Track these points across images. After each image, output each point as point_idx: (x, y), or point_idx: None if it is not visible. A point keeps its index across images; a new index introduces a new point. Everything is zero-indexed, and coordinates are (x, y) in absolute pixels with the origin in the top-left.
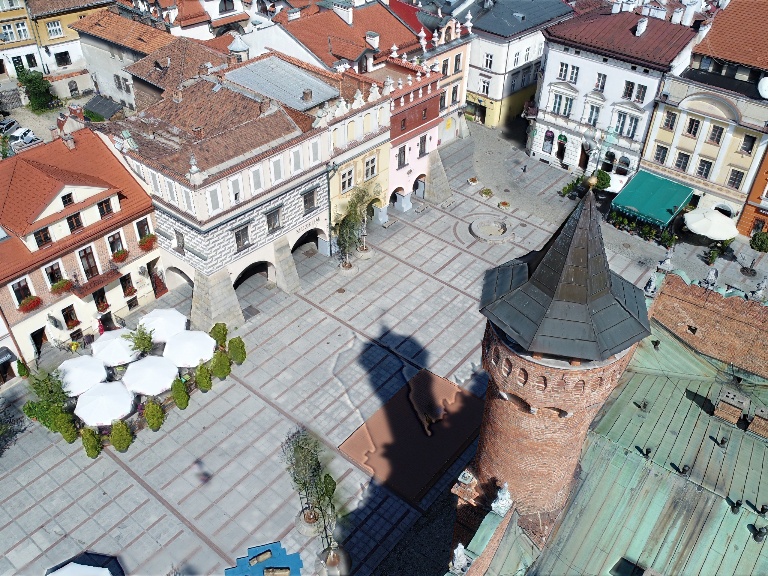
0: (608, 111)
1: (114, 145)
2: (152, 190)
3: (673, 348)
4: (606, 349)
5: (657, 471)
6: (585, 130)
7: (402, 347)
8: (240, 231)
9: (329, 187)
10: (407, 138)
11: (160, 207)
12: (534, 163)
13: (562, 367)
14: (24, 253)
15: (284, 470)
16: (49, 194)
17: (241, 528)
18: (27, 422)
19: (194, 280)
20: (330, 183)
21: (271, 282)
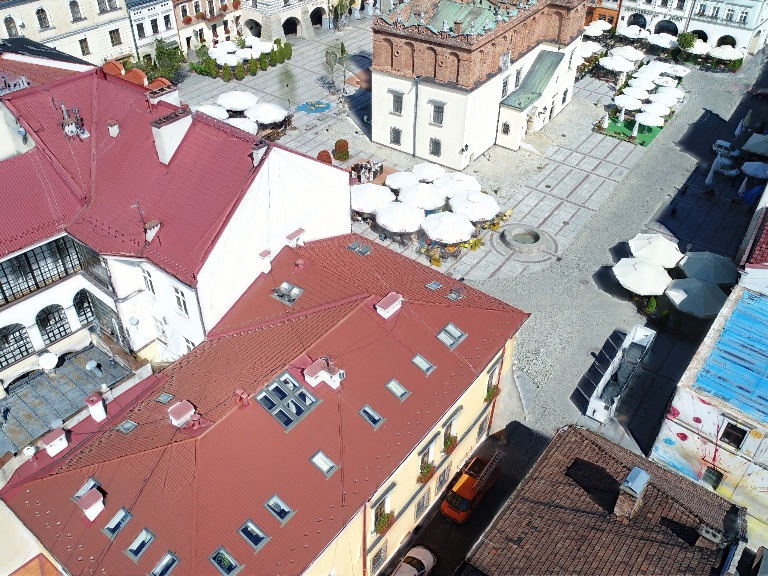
0: None
1: None
2: None
3: None
4: None
5: (465, 6)
6: None
7: (371, 56)
8: None
9: None
10: None
11: None
12: None
13: None
14: None
15: (318, 86)
16: None
17: (302, 98)
18: (190, 74)
19: (262, 21)
20: None
21: (299, 36)
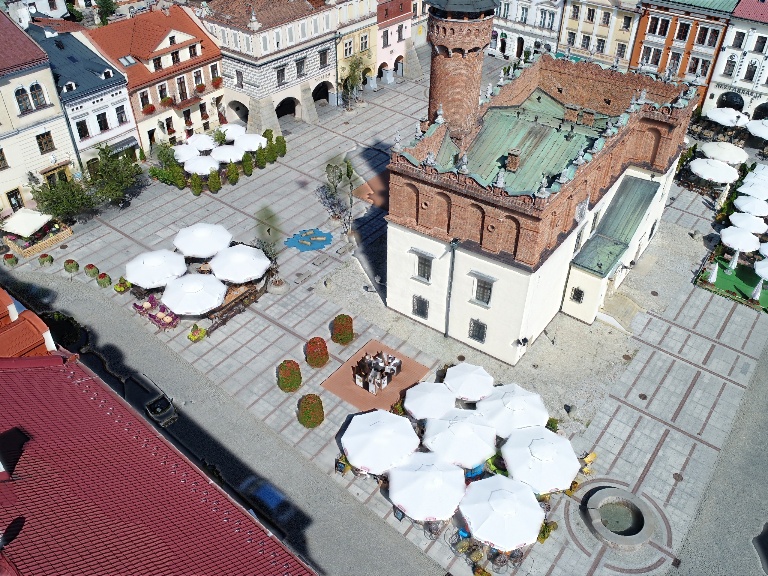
0: (534, 10)
1: (195, 14)
2: (221, 43)
3: (550, 103)
4: (478, 8)
5: (523, 122)
6: (519, 27)
7: None
8: (280, 70)
9: (336, 51)
10: (389, 23)
11: (227, 54)
12: (484, 57)
13: (460, 21)
14: (147, 73)
15: (317, 201)
16: (162, 35)
17: (294, 223)
18: (151, 181)
19: (249, 105)
20: (337, 48)
21: (298, 118)
